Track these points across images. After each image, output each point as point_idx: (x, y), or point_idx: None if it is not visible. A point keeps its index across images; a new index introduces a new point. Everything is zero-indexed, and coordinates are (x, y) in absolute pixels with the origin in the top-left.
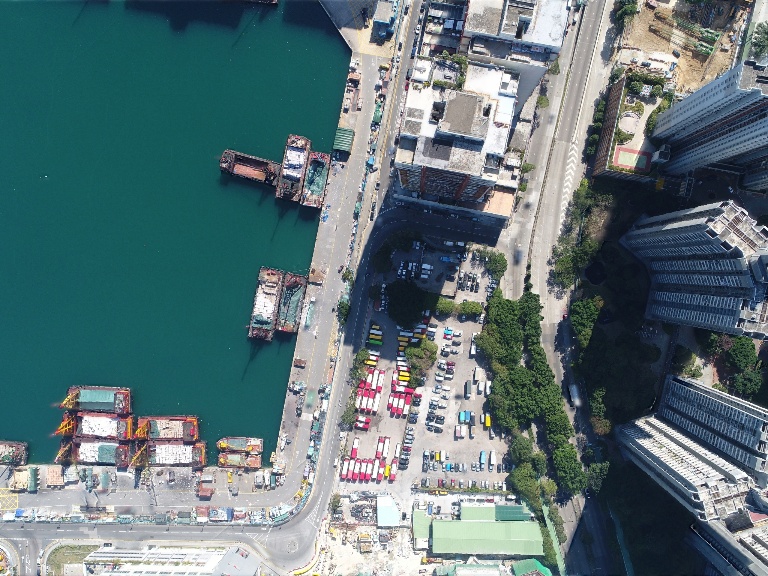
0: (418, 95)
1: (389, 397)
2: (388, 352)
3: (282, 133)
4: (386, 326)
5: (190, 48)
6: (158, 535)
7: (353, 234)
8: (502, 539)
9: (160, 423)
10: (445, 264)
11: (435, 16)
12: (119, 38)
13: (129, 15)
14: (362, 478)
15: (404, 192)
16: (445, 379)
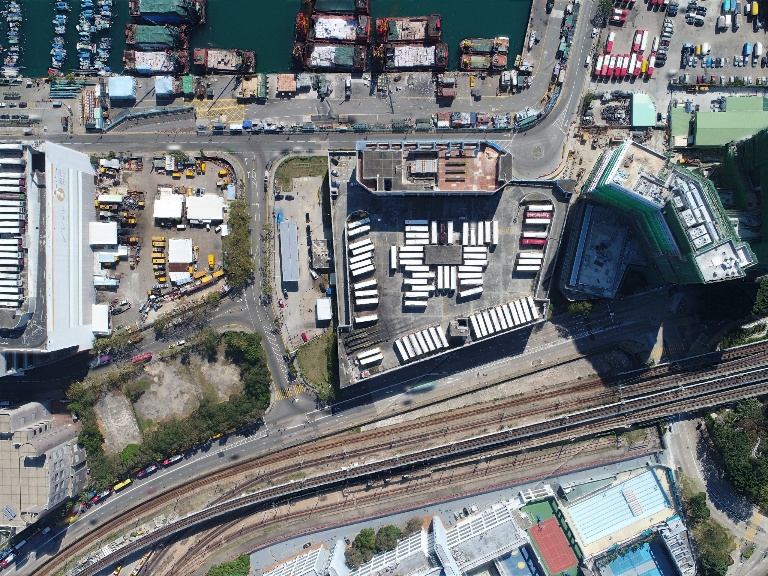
0: None
1: None
2: None
3: None
4: None
5: None
6: None
7: None
8: None
9: (399, 24)
10: None
11: None
12: None
13: None
14: (618, 73)
15: None
16: None
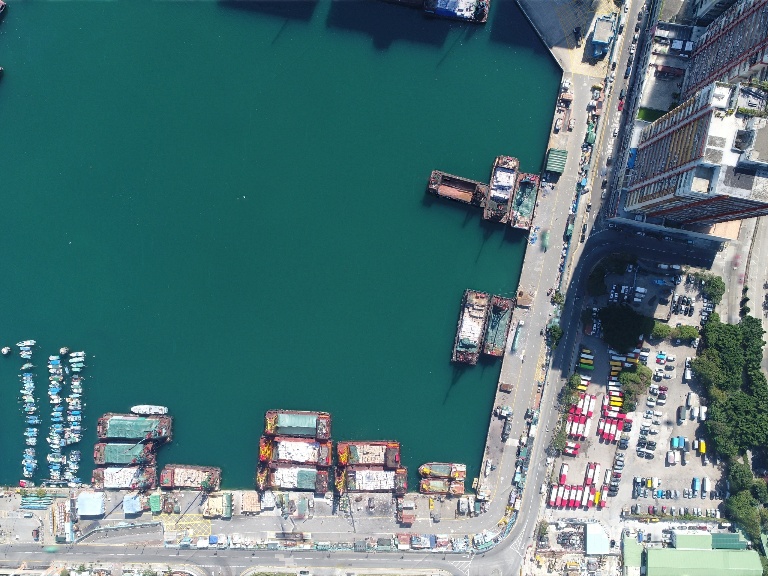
0: (720, 123)
1: (599, 422)
2: (598, 377)
3: (489, 154)
4: (596, 350)
5: (394, 67)
6: (357, 562)
7: (563, 256)
8: (720, 568)
9: (360, 448)
10: (659, 287)
11: (662, 36)
12: (320, 57)
13: (332, 33)
14: (571, 505)
15: (627, 215)
16: (657, 404)
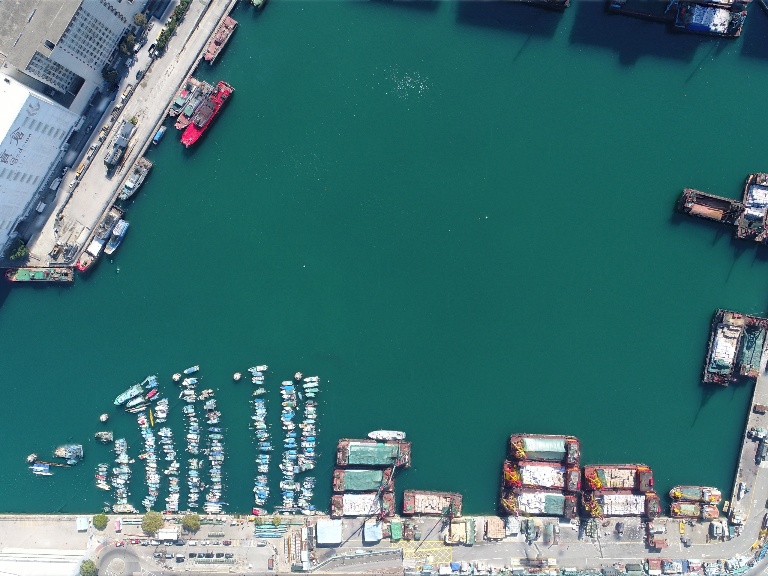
0: None
1: None
2: None
3: (741, 171)
4: None
5: (642, 83)
6: None
7: None
8: None
9: (608, 472)
10: None
11: None
12: (564, 74)
13: (577, 50)
14: None
15: None
16: None
